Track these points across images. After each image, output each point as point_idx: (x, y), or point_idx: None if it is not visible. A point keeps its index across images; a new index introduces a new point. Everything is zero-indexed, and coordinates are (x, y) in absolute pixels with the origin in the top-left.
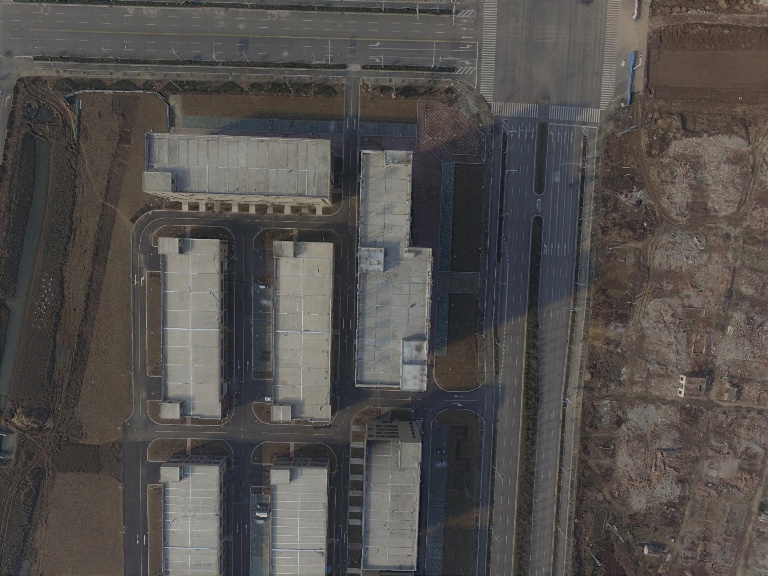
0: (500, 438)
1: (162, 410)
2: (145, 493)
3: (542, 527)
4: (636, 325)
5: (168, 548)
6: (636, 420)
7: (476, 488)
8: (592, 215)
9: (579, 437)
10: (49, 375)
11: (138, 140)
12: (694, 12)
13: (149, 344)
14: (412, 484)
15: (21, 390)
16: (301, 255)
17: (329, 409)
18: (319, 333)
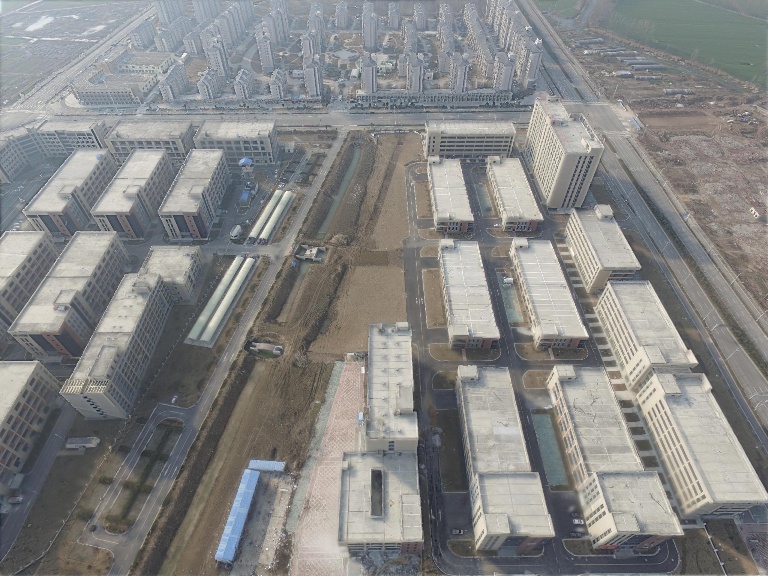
0: (656, 241)
1: (438, 214)
2: (420, 274)
3: (720, 286)
4: (704, 193)
5: (449, 286)
6: (740, 231)
7: (656, 266)
8: (648, 159)
9: (709, 239)
10: (355, 221)
11: (407, 144)
12: (651, 109)
13: (418, 206)
14: (613, 228)
15: (337, 228)
16: (503, 163)
17: (540, 216)
18: (522, 188)
